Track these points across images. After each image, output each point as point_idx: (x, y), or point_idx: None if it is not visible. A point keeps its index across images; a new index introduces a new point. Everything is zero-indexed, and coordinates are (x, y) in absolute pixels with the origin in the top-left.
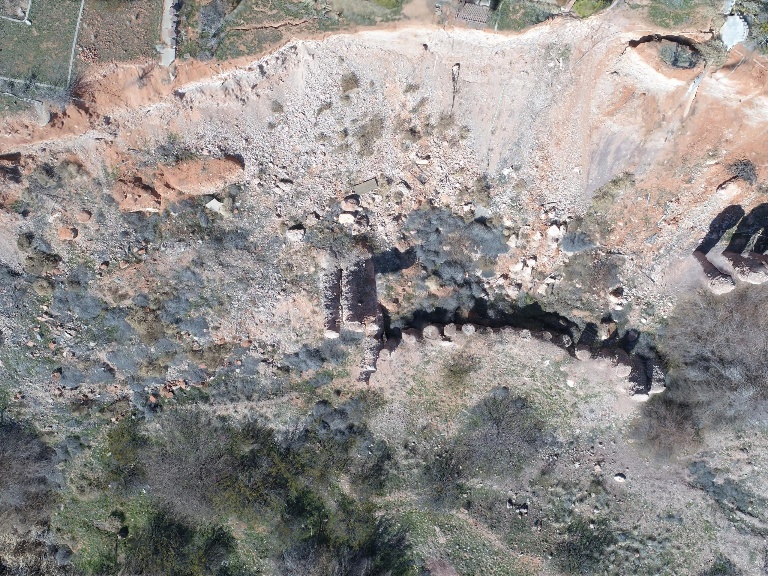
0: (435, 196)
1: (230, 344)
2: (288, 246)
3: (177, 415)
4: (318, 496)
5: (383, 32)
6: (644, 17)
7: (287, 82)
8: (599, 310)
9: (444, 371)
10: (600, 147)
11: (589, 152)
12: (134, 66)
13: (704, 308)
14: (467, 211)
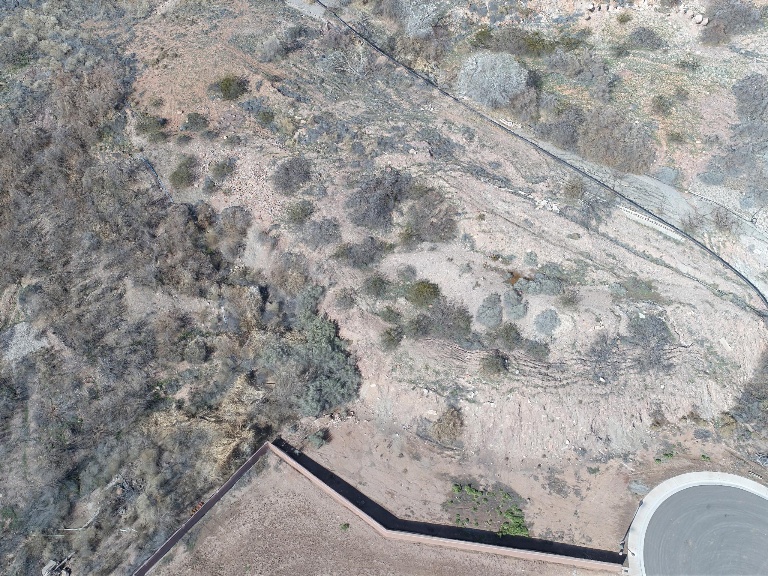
0: None
1: (533, 10)
2: None
3: (507, 28)
4: None
5: None
6: None
7: None
8: None
9: (617, 21)
10: None
11: None
12: None
13: None
14: None
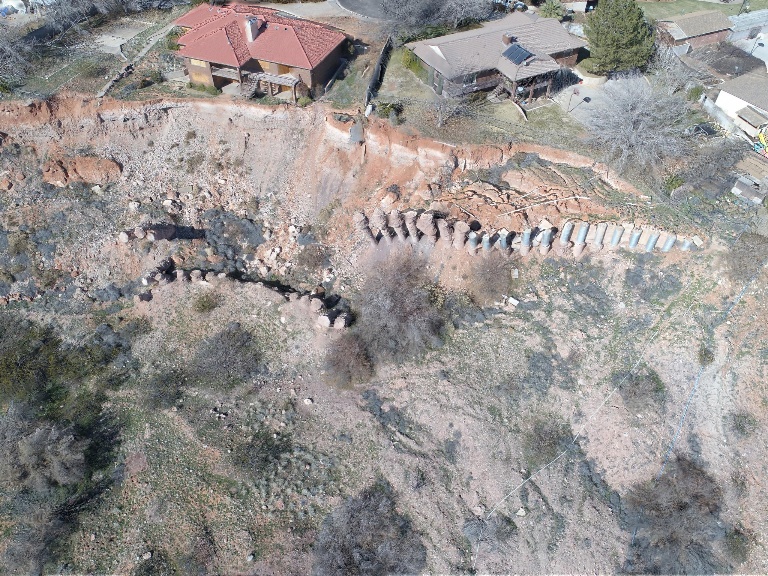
0: (226, 205)
1: (64, 272)
2: (127, 212)
3: (0, 315)
4: (67, 390)
5: (208, 105)
6: (329, 106)
7: (160, 132)
8: (316, 283)
9: (198, 306)
10: (322, 184)
11: (316, 186)
12: (83, 96)
13: (381, 279)
14: (243, 215)
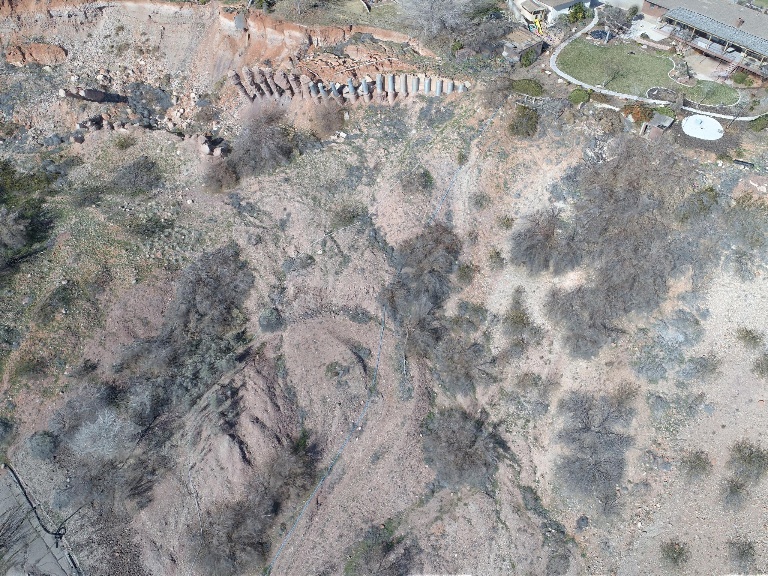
0: (145, 80)
1: (20, 125)
2: (69, 84)
3: None
4: None
5: (132, 4)
6: None
7: (96, 27)
8: None
9: (118, 146)
10: (217, 63)
11: (213, 65)
12: None
13: None
14: None
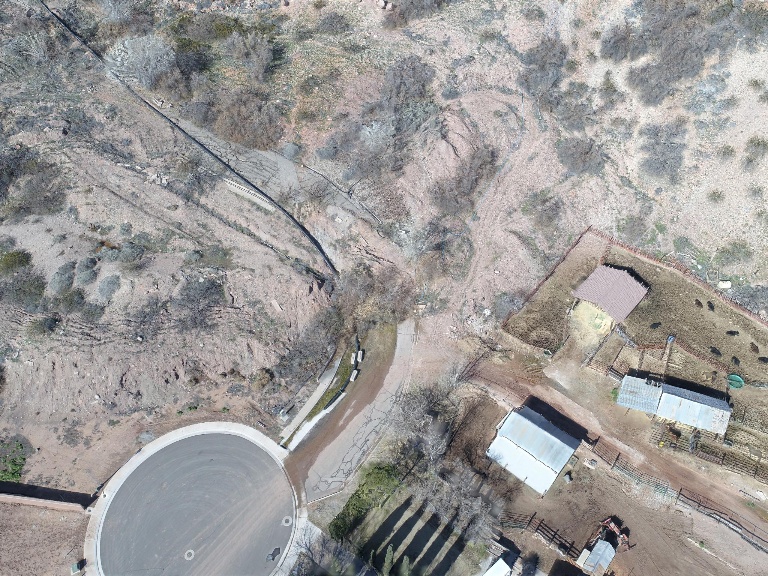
0: None
1: None
2: None
3: (210, 14)
4: None
5: None
6: None
7: None
8: None
9: (314, 7)
10: None
11: None
12: None
13: None
14: None
